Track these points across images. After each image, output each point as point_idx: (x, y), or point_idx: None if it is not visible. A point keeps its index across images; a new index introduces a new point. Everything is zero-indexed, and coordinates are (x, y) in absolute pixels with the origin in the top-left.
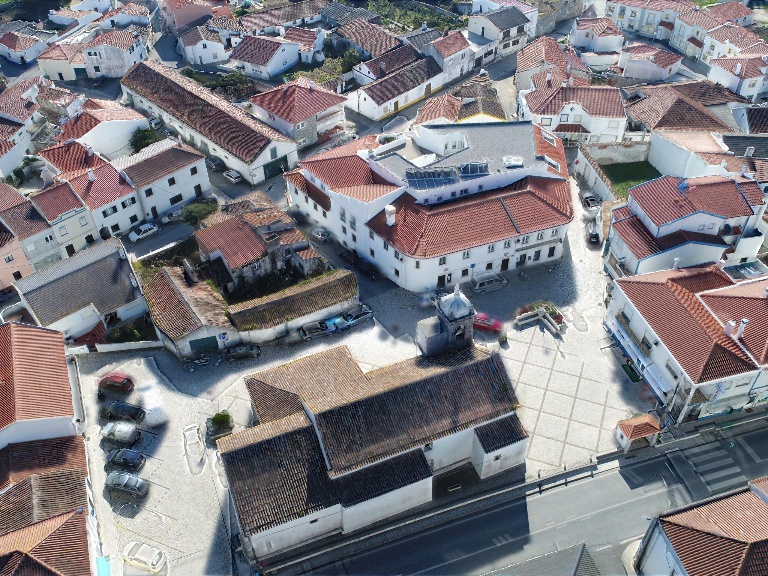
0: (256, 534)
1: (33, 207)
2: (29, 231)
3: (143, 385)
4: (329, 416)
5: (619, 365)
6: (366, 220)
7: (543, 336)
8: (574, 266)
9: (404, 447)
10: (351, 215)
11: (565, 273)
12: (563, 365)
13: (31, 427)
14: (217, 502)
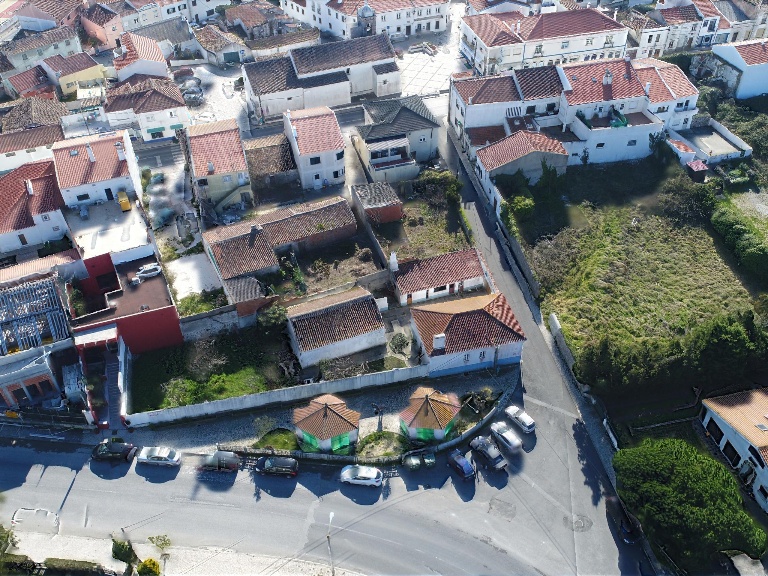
0: (261, 95)
1: (126, 3)
2: (126, 13)
3: (198, 75)
4: (298, 51)
5: (463, 64)
6: (326, 3)
7: (424, 55)
8: (451, 34)
9: (335, 67)
10: (318, 4)
11: (445, 36)
12: (432, 64)
13: (147, 65)
14: (241, 106)
